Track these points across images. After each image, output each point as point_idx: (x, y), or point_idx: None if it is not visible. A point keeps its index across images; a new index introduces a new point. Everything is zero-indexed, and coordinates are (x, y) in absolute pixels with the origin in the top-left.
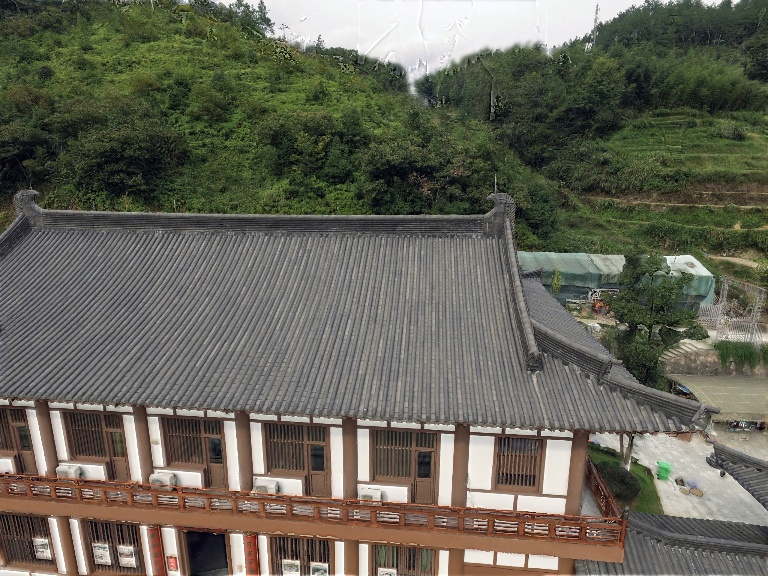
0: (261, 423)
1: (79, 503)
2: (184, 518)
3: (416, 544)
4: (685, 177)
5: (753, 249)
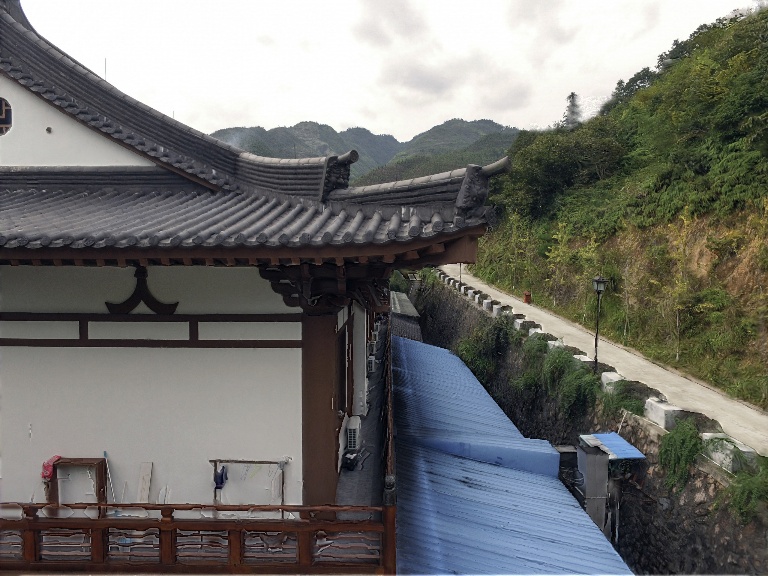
0: None
1: None
2: None
3: None
4: None
5: None
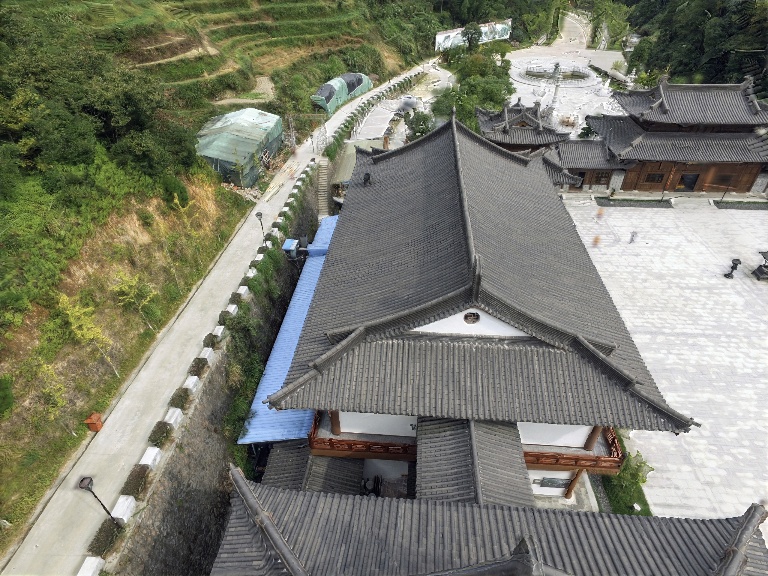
0: None
1: None
2: None
3: None
4: (124, 35)
5: (228, 89)
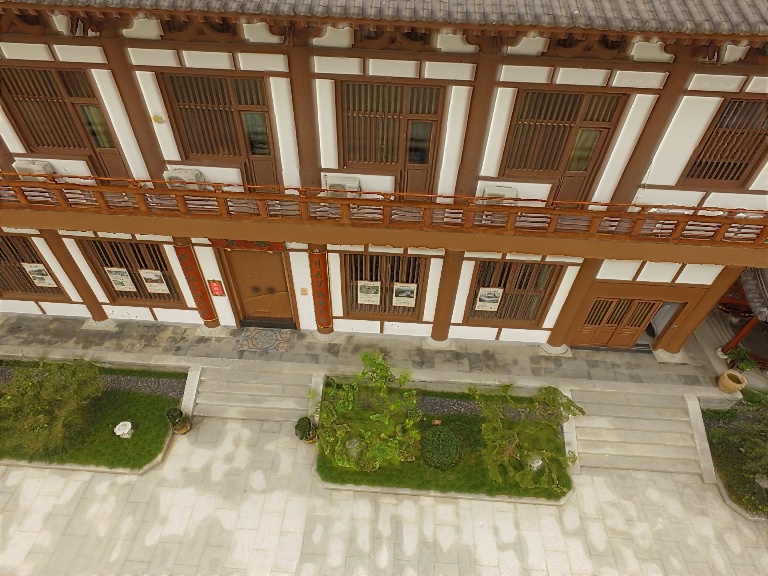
0: (335, 80)
1: (67, 210)
2: (231, 228)
3: (540, 259)
4: None
5: None
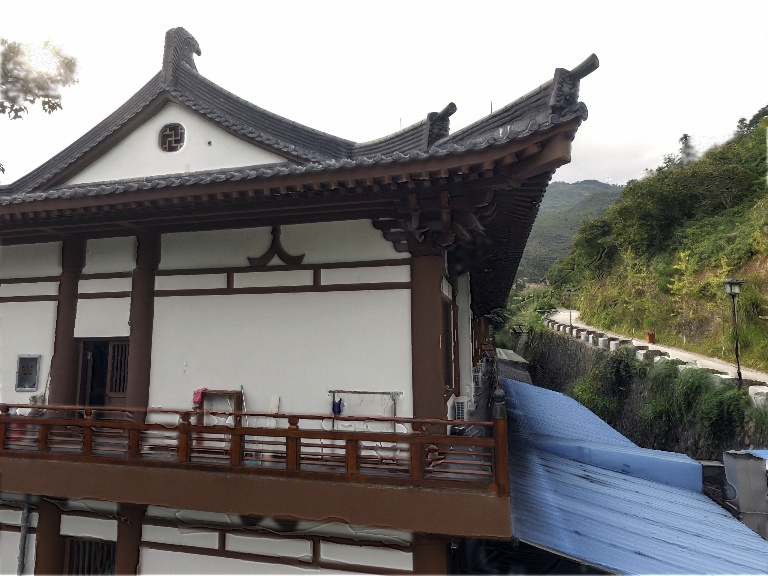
0: None
1: None
2: None
3: None
4: None
5: None
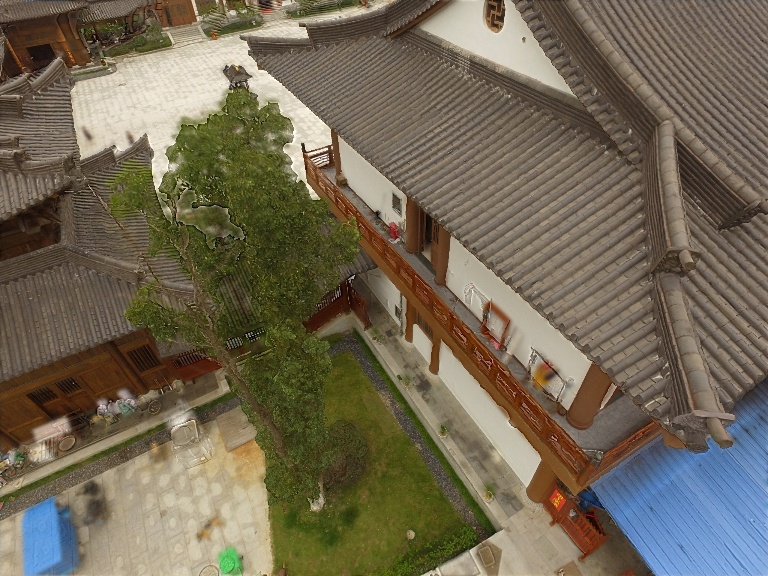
0: None
1: None
2: None
3: None
4: None
5: None
